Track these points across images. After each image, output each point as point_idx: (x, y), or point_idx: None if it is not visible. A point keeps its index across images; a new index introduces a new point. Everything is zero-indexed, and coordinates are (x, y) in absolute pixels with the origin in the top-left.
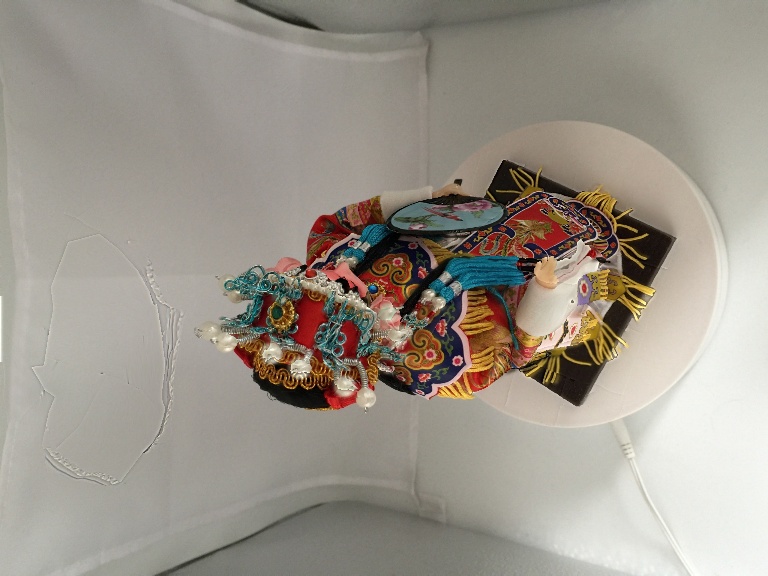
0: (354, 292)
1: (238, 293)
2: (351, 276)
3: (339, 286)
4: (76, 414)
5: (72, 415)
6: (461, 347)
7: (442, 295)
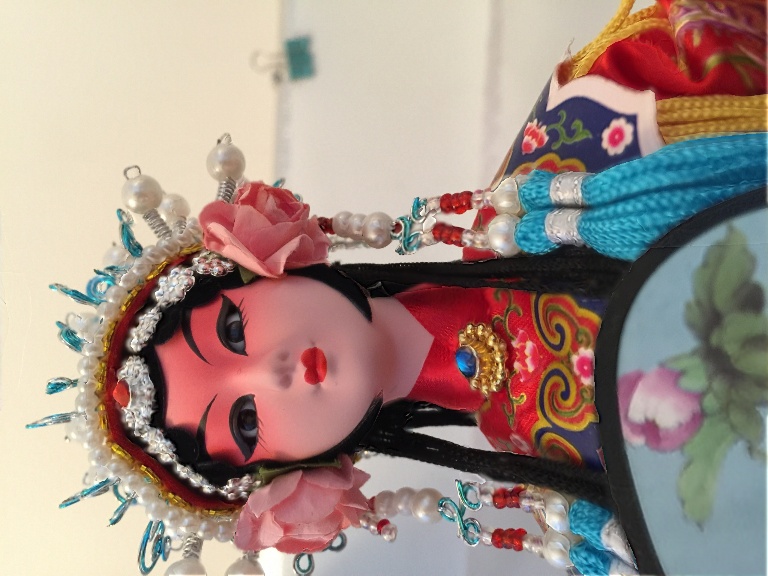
0: (198, 472)
1: (217, 176)
2: (281, 396)
3: (164, 450)
4: (18, 263)
5: (17, 260)
6: None
7: (569, 555)
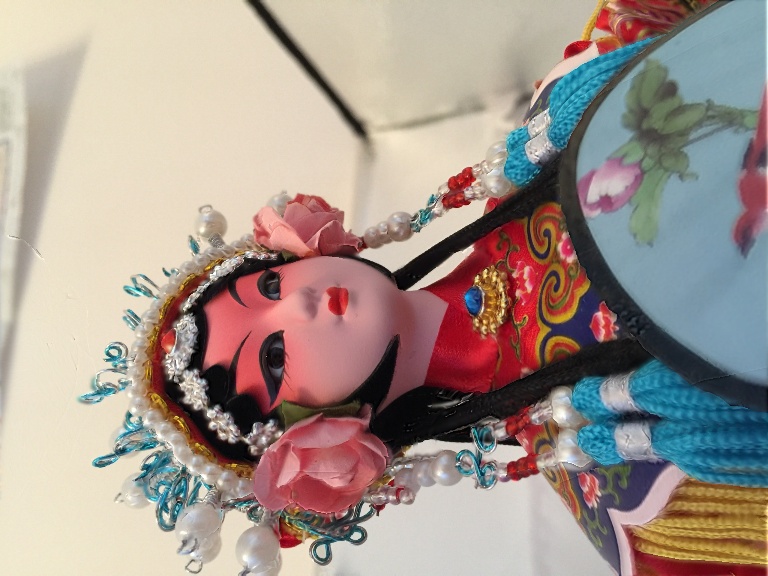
0: (226, 411)
1: None
2: (307, 327)
3: (197, 391)
4: None
5: None
6: (617, 563)
7: None
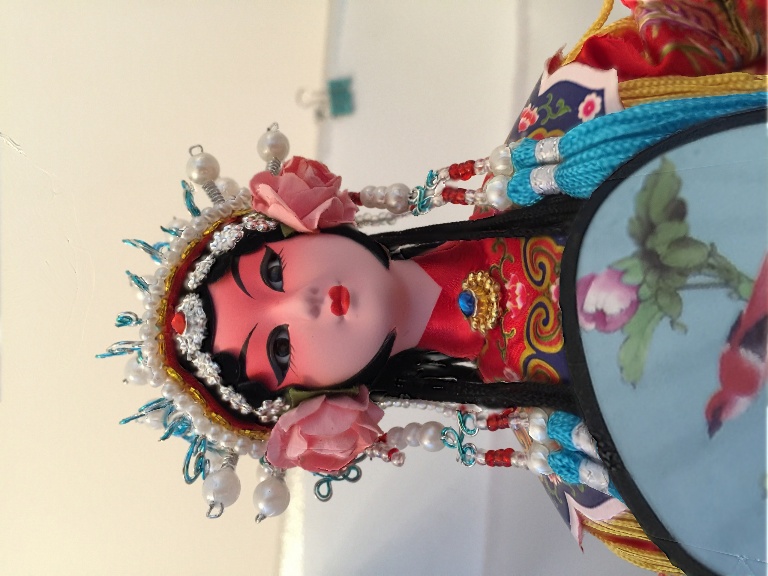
0: (238, 392)
1: (265, 156)
2: (311, 325)
3: (210, 372)
4: None
5: None
6: (567, 522)
7: None
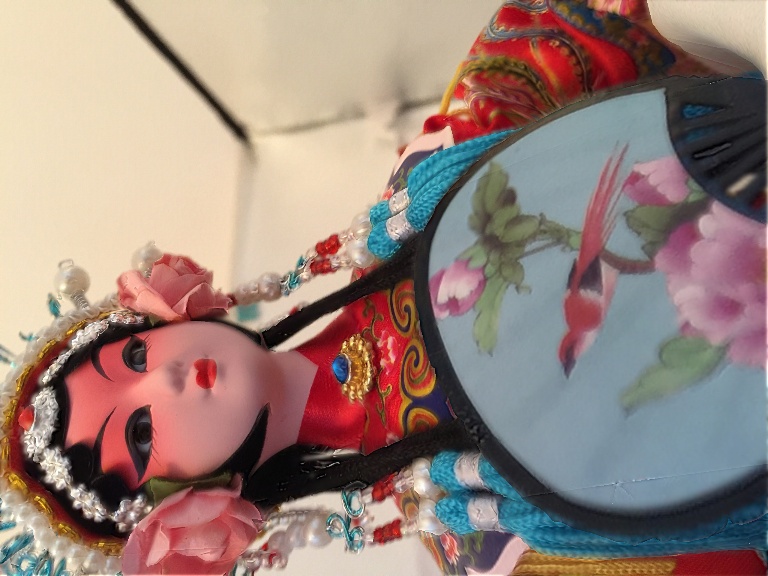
0: (90, 491)
1: (140, 268)
2: (175, 402)
3: (59, 471)
4: None
5: None
6: None
7: None
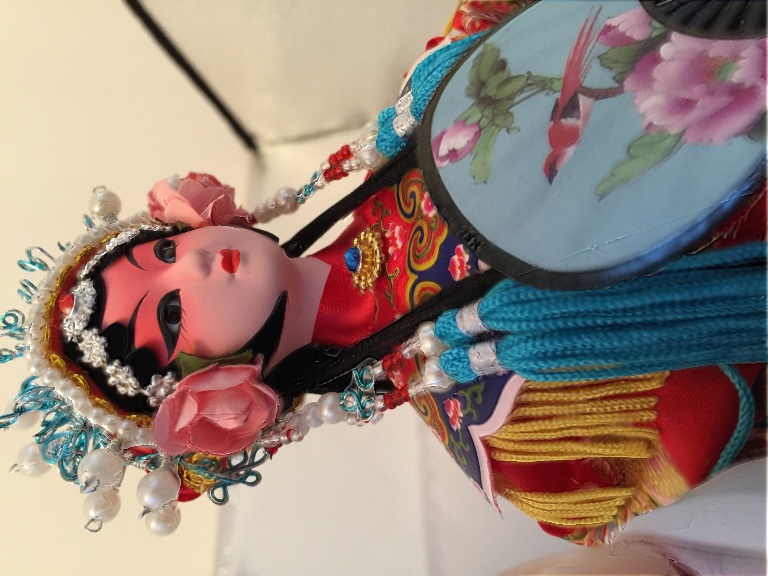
0: (125, 365)
1: None
2: (202, 285)
3: (97, 348)
4: None
5: None
6: (478, 475)
7: (440, 365)
